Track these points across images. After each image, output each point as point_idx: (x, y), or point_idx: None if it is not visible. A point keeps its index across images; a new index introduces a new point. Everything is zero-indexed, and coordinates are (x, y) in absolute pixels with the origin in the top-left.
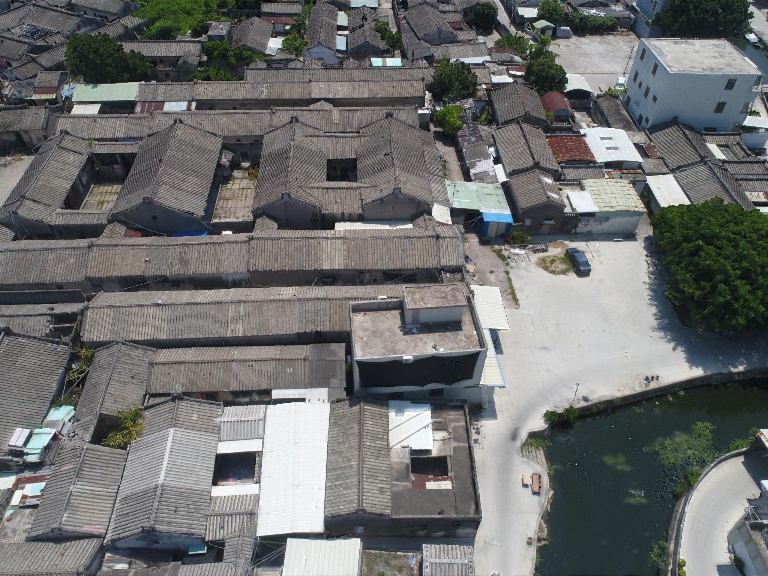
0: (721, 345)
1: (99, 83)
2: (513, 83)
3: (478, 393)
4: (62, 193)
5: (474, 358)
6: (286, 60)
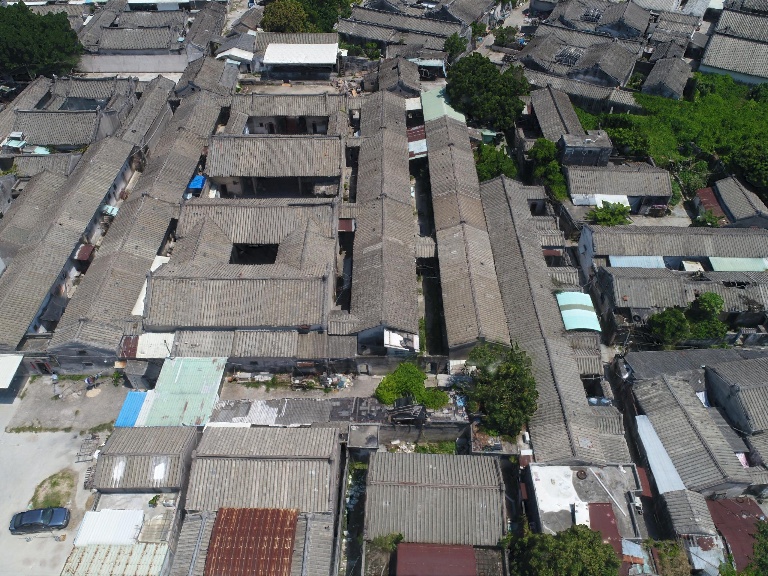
0: None
1: (448, 97)
2: (499, 484)
3: None
4: (270, 113)
5: None
6: (568, 216)
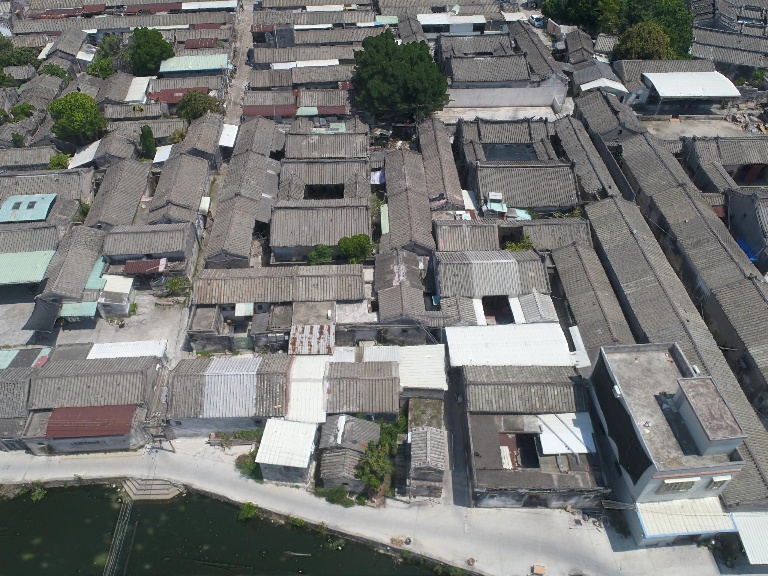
0: None
1: None
2: None
3: (636, 519)
4: (743, 160)
5: (646, 464)
6: None
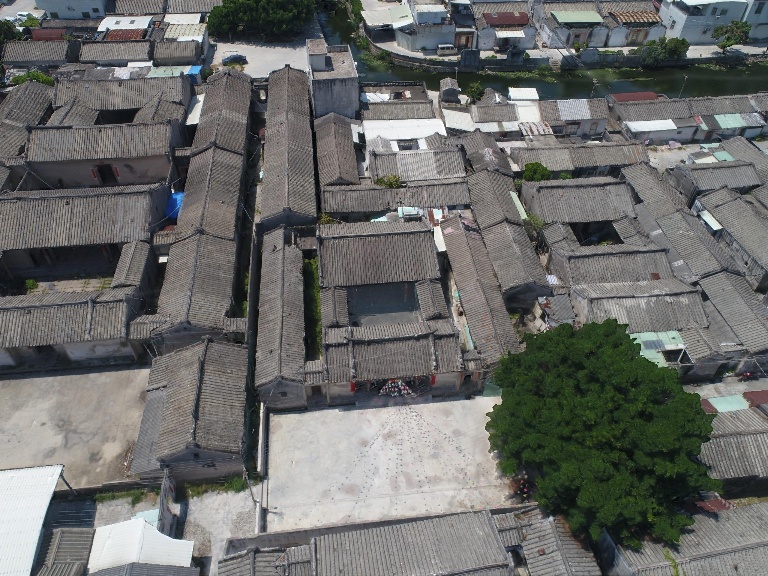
0: (306, 36)
1: None
2: (7, 43)
3: None
4: (75, 293)
5: None
6: None
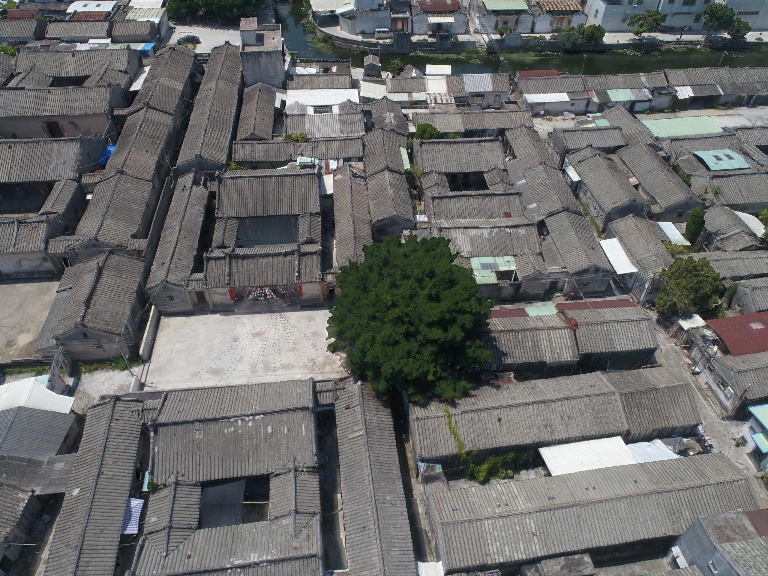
0: (259, 21)
1: None
2: None
3: None
4: None
5: None
6: None
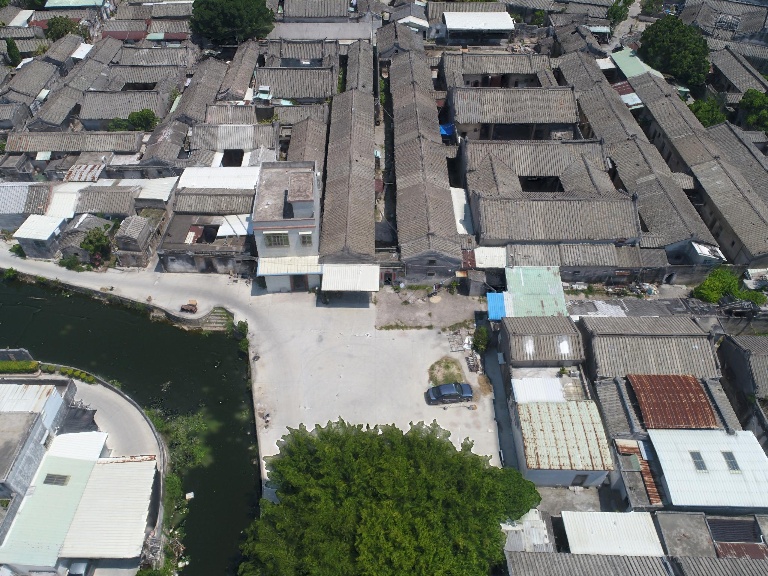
0: None
1: (641, 57)
2: None
3: None
4: (481, 71)
5: None
6: None
